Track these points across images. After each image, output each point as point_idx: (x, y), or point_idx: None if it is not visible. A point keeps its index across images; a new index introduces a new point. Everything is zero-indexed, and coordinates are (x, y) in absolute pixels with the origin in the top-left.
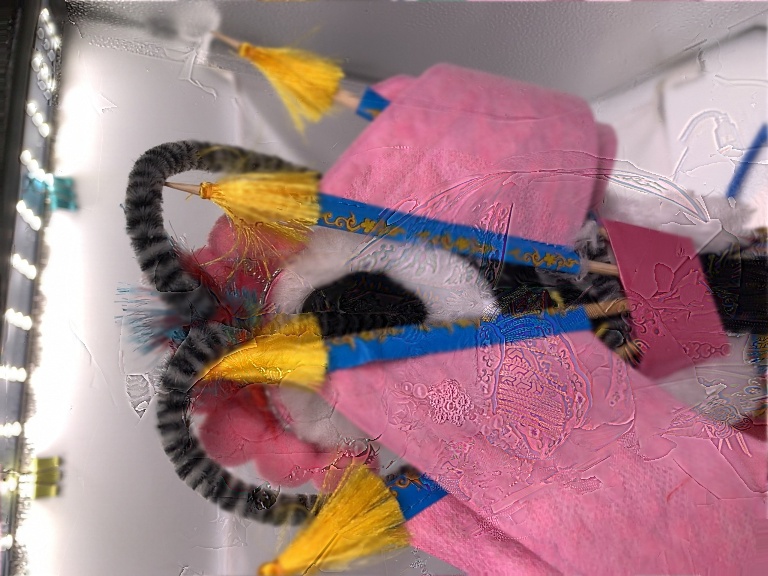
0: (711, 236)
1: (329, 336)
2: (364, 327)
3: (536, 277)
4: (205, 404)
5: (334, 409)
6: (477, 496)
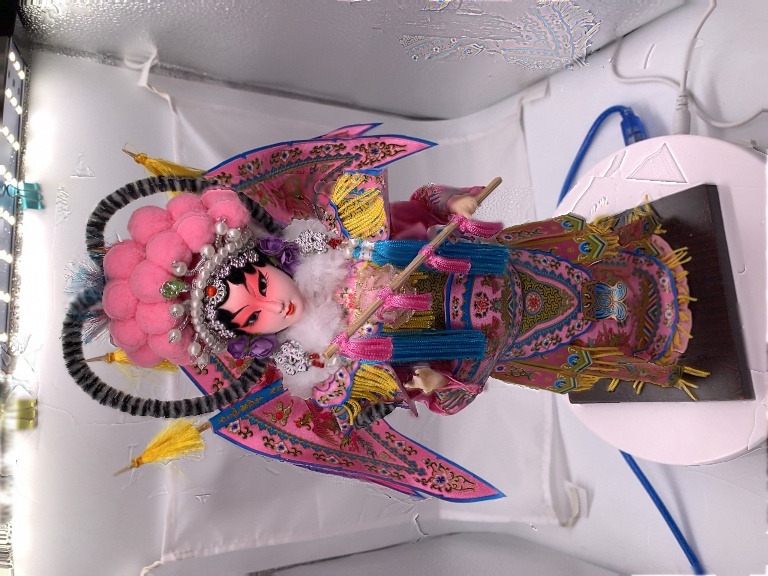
0: None
1: (194, 194)
2: (217, 186)
3: None
4: None
5: None
6: None
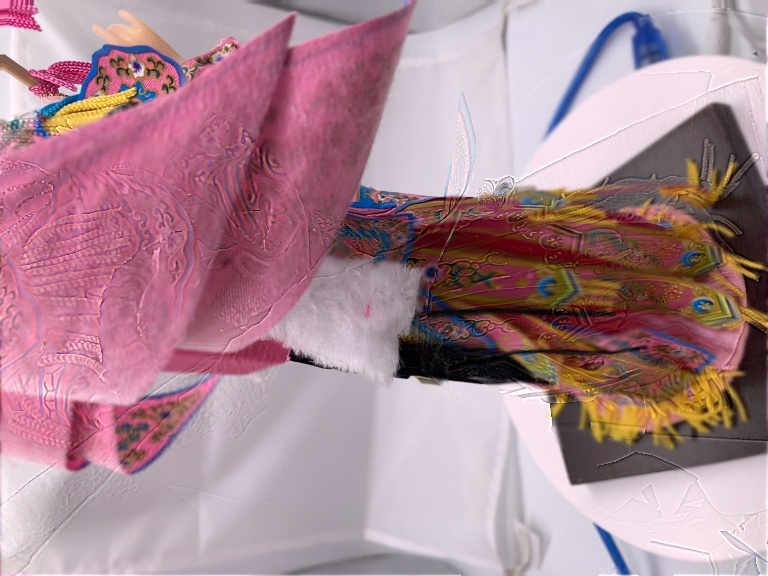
0: (604, 428)
1: None
2: None
3: None
4: None
5: None
6: None
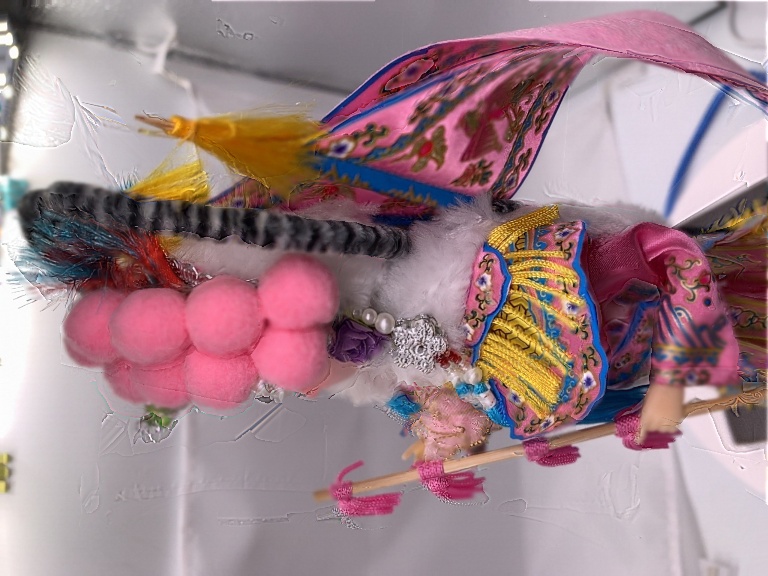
0: None
1: (266, 244)
2: (319, 241)
3: (570, 191)
4: (86, 299)
5: (258, 344)
6: (430, 447)
